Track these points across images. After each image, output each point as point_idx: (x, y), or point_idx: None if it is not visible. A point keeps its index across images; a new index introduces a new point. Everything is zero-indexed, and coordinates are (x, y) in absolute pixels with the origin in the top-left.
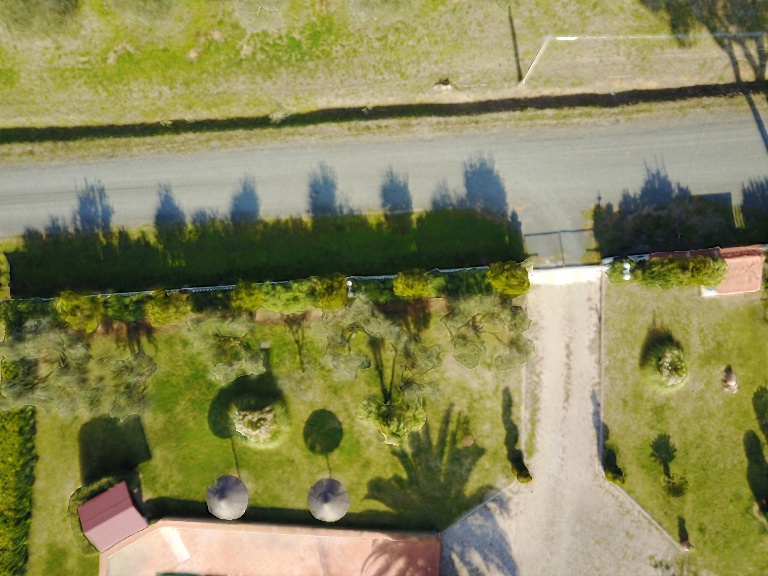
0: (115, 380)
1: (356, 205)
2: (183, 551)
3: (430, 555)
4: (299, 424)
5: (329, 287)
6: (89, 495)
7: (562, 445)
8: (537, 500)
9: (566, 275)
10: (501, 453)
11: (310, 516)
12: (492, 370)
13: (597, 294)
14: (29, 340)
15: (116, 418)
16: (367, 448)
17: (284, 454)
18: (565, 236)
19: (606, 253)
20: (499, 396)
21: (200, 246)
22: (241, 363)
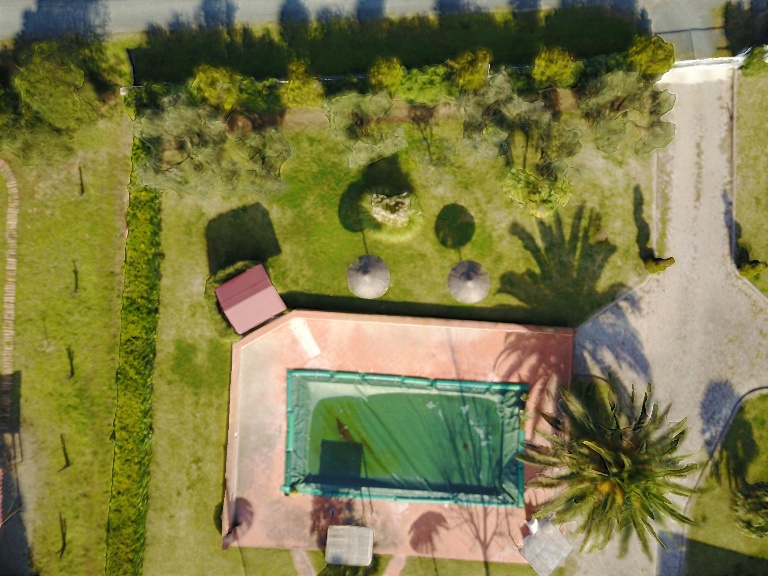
0: (248, 167)
1: (484, 2)
2: (314, 347)
3: (563, 351)
4: (431, 218)
5: (473, 60)
6: (226, 277)
7: (694, 244)
8: (669, 299)
9: (697, 73)
10: (633, 251)
11: (443, 310)
12: (623, 168)
13: (728, 93)
14: (169, 113)
15: (244, 214)
16: (500, 242)
17: (416, 248)
18: (696, 34)
19: (737, 51)
20: (630, 194)
21: (326, 44)
22: (379, 146)
